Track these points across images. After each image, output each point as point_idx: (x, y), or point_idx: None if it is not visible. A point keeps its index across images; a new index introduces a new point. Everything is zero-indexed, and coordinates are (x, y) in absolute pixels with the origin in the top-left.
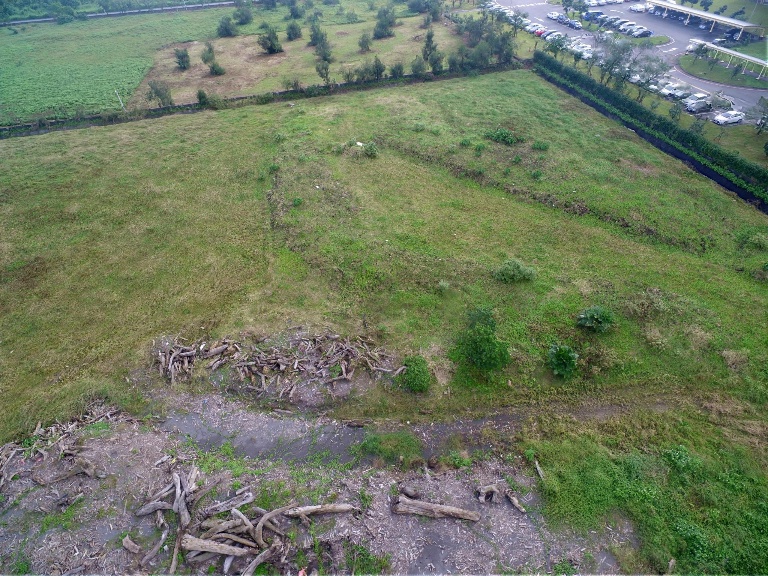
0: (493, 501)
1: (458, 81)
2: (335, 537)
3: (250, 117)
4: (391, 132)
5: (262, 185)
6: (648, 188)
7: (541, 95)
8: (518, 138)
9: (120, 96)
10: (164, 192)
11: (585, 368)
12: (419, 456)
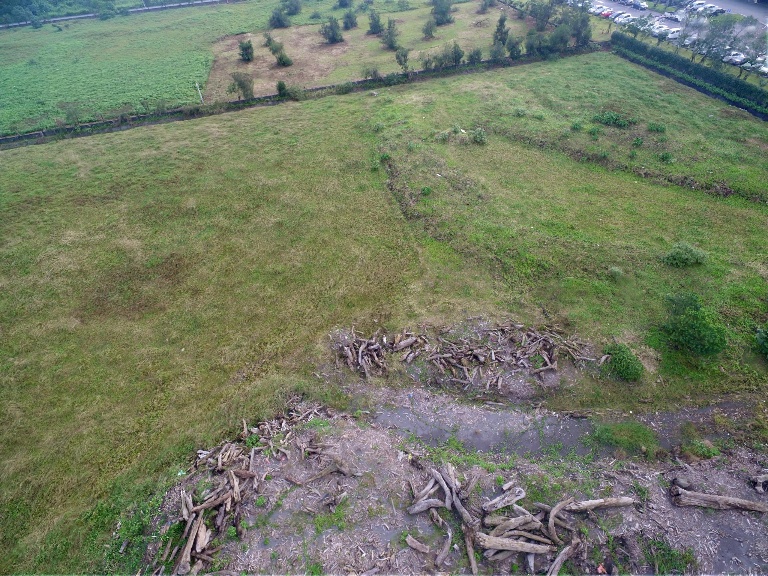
0: None
1: (540, 65)
2: (629, 532)
3: (336, 107)
4: (491, 118)
5: (378, 175)
6: None
7: (634, 77)
8: (630, 120)
9: (193, 90)
10: (278, 185)
11: None
12: (658, 446)
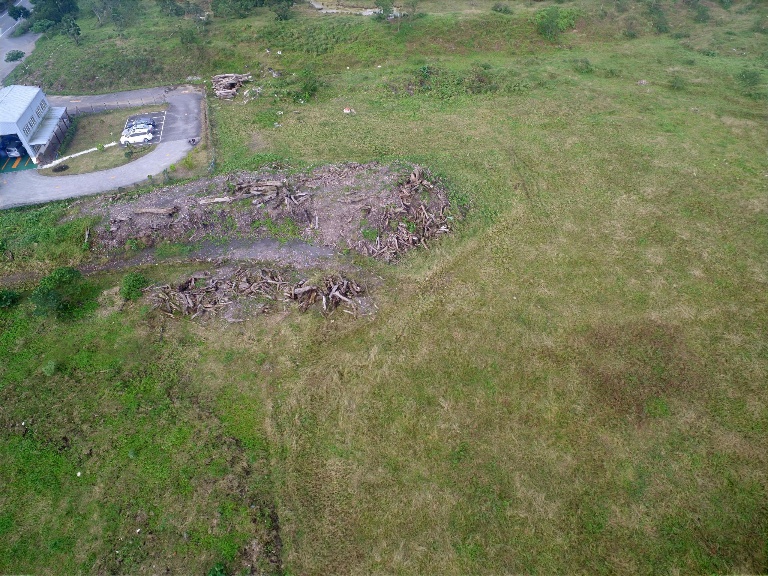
0: None
1: None
2: None
3: None
4: None
5: None
6: None
7: None
8: None
9: None
10: None
11: None
12: None
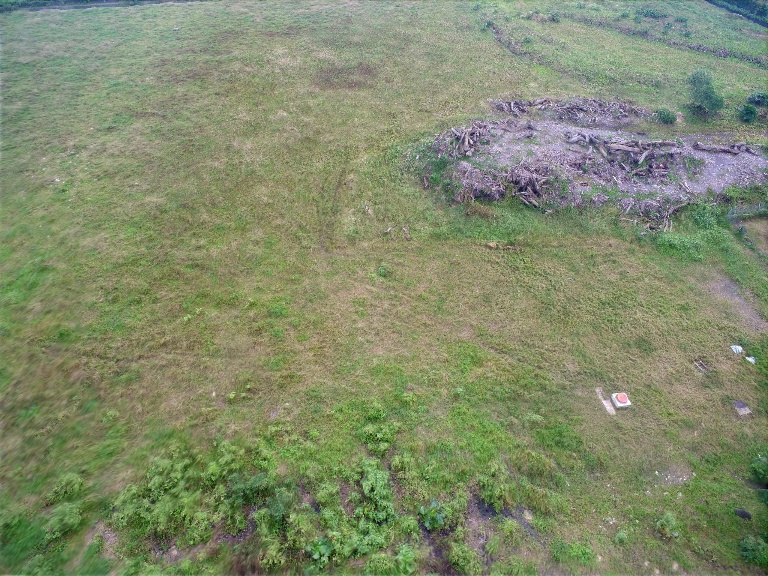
0: (741, 150)
1: None
2: (675, 152)
3: None
4: (560, 8)
5: (487, 33)
6: (767, 44)
7: None
8: (662, 14)
9: None
10: (415, 34)
11: (759, 119)
12: None
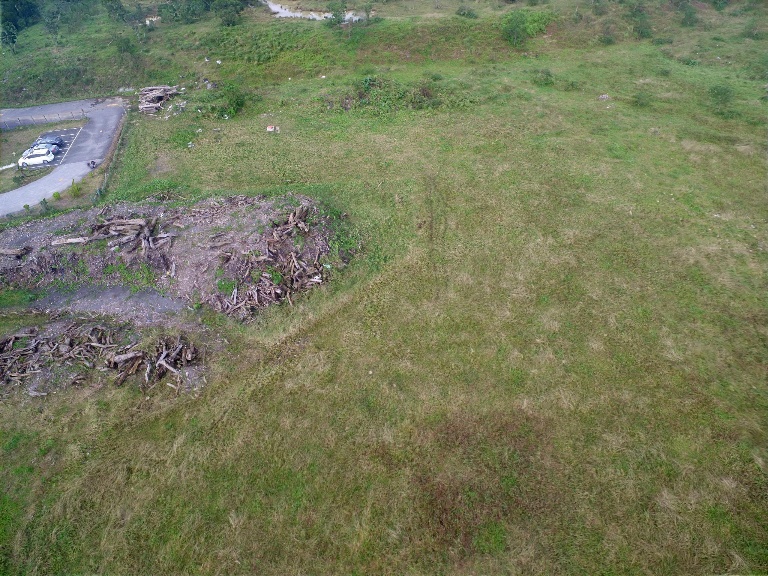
0: None
1: None
2: None
3: None
4: None
5: None
6: None
7: None
8: None
9: None
10: None
11: None
12: None
